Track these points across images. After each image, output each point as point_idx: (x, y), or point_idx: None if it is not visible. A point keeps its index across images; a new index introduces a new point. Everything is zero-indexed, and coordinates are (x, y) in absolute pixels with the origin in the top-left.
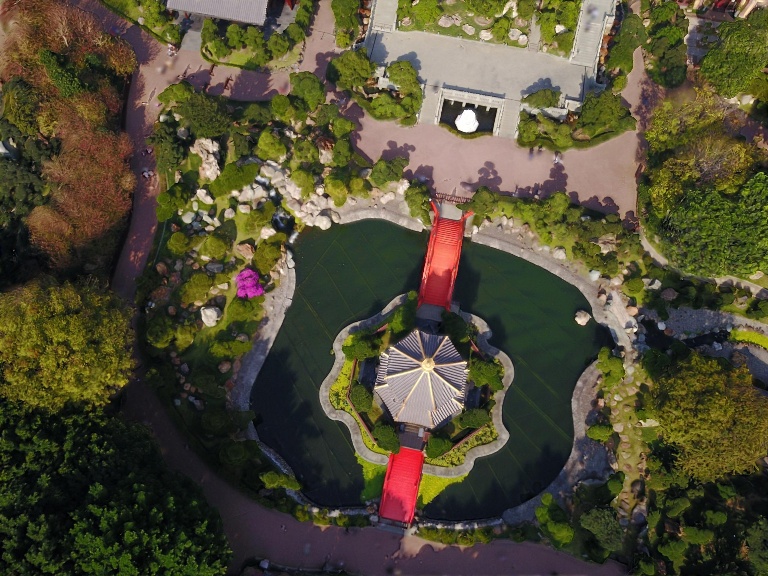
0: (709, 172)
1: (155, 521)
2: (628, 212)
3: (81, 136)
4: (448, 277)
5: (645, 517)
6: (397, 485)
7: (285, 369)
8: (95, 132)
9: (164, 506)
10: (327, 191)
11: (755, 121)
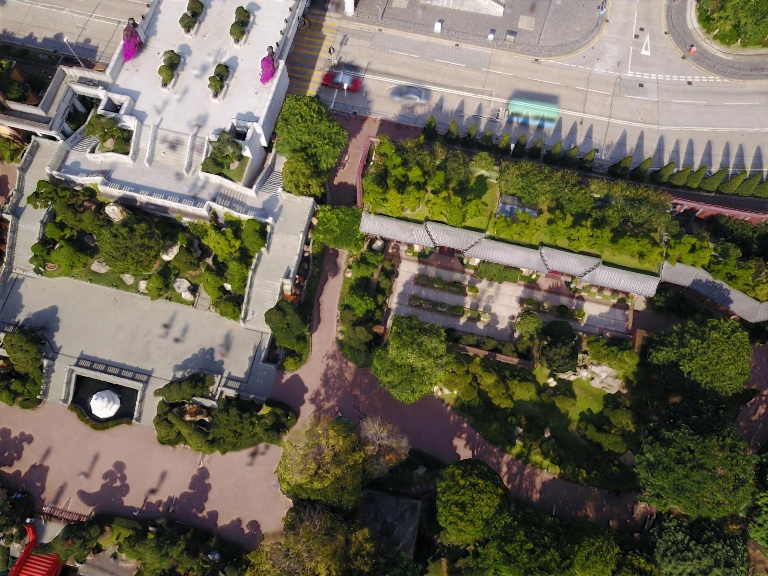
0: None
1: None
2: (275, 544)
3: None
4: None
5: None
6: None
7: None
8: None
9: None
10: None
11: (459, 416)
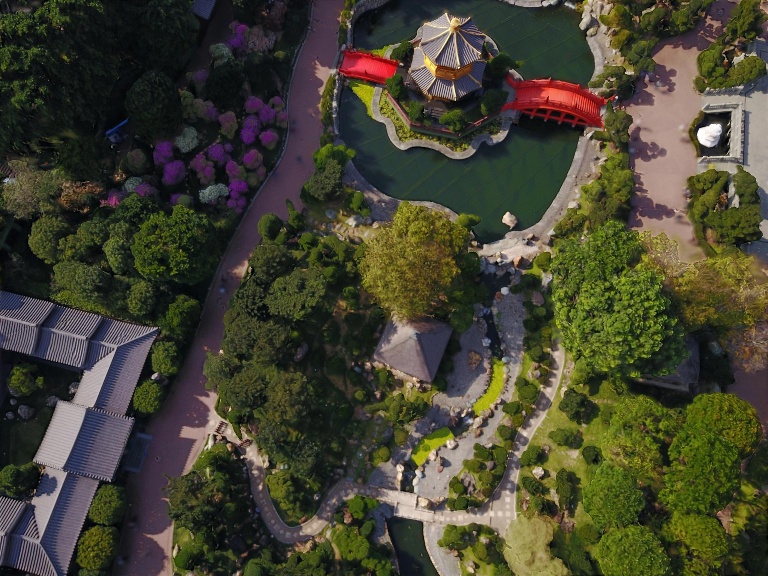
0: None
1: None
2: None
3: None
4: None
5: None
6: (367, 64)
7: (457, 2)
8: None
9: None
10: None
11: (766, 433)
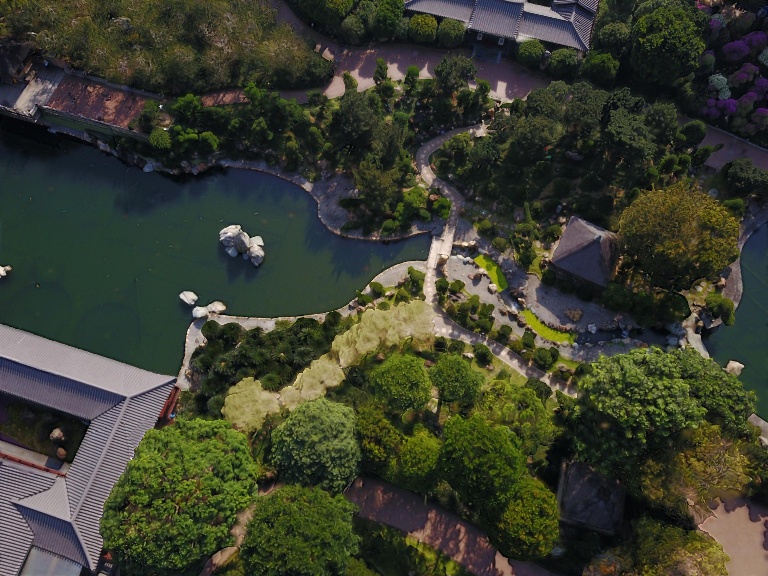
0: None
1: None
2: None
3: None
4: None
5: None
6: None
7: None
8: None
9: None
10: None
11: None
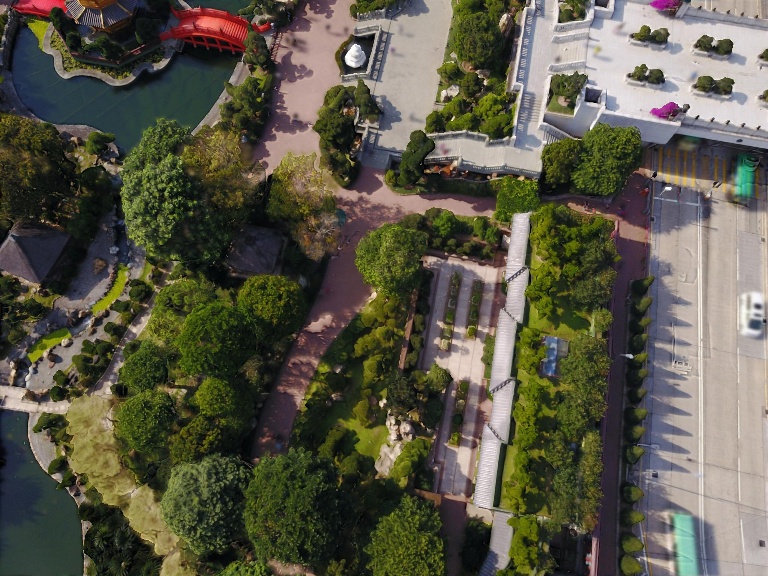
0: None
1: None
2: None
3: None
4: None
5: None
6: (40, 0)
7: None
8: None
9: None
10: None
11: None
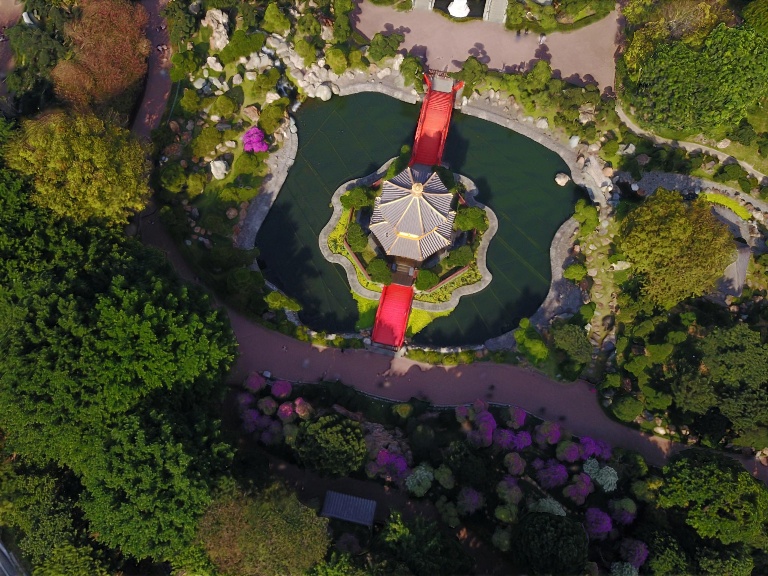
0: (677, 28)
1: (171, 305)
2: (607, 87)
3: (101, 3)
4: (438, 138)
5: (614, 344)
6: (389, 314)
7: (287, 219)
8: (114, 0)
9: (179, 296)
10: (328, 61)
11: None
